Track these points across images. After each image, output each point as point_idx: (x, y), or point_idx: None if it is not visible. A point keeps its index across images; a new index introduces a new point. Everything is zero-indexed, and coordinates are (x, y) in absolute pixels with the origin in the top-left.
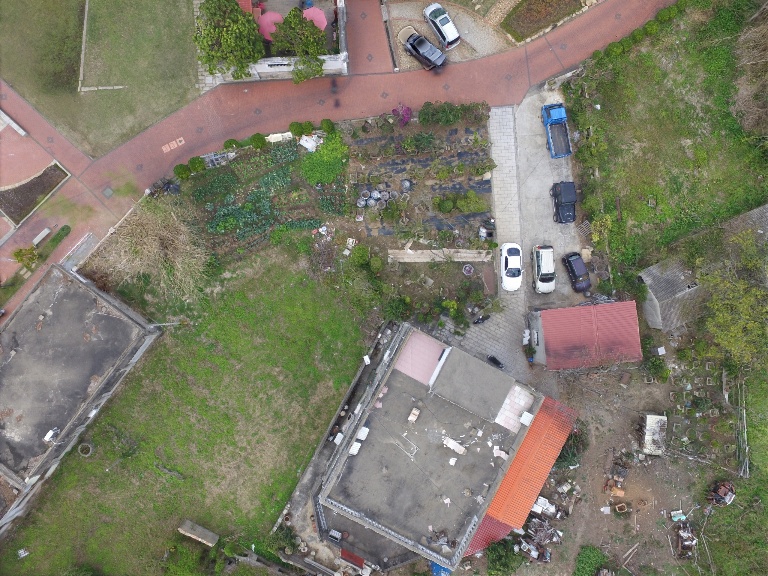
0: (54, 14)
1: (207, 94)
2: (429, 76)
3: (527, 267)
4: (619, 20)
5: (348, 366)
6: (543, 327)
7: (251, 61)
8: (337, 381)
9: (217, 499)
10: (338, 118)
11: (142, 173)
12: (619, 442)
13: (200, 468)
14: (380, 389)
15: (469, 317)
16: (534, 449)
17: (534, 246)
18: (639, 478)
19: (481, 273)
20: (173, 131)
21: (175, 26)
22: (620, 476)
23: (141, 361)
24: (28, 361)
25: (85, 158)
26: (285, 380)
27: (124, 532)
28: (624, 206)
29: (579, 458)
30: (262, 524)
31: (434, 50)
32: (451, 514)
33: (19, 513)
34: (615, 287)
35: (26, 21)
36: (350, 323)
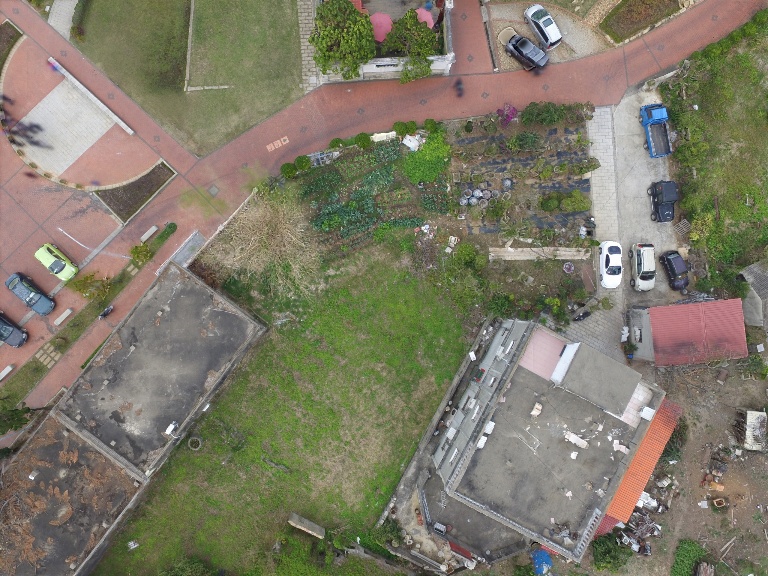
0: (160, 15)
1: (311, 94)
2: (529, 76)
3: (625, 265)
4: (716, 21)
5: (450, 362)
6: (651, 324)
7: (362, 62)
8: (439, 377)
9: (323, 492)
10: (439, 118)
11: (247, 172)
12: (716, 438)
13: (306, 462)
14: (506, 384)
15: (569, 314)
16: (641, 444)
17: (634, 244)
18: (736, 473)
19: (580, 271)
20: (277, 130)
21: (280, 27)
22: (719, 471)
23: (247, 357)
24: (147, 356)
25: (191, 157)
26: (388, 376)
27: (231, 525)
28: (721, 205)
29: (681, 453)
30: (366, 517)
31: (537, 51)
32: (573, 507)
33: (129, 506)
34: (713, 285)
35: (132, 21)
36: (452, 320)
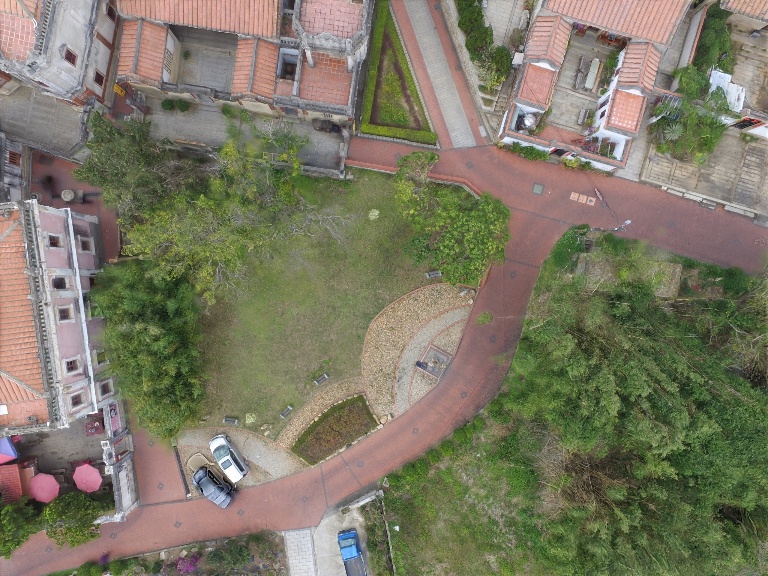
0: None
1: None
2: None
3: None
4: (417, 435)
5: None
6: None
7: None
8: None
9: None
10: (131, 551)
11: None
12: None
13: None
14: None
15: None
16: None
17: None
18: None
19: None
20: None
21: None
22: None
23: None
24: None
25: None
26: None
27: None
28: None
29: None
30: None
31: (218, 494)
32: None
33: None
34: None
35: None
36: None
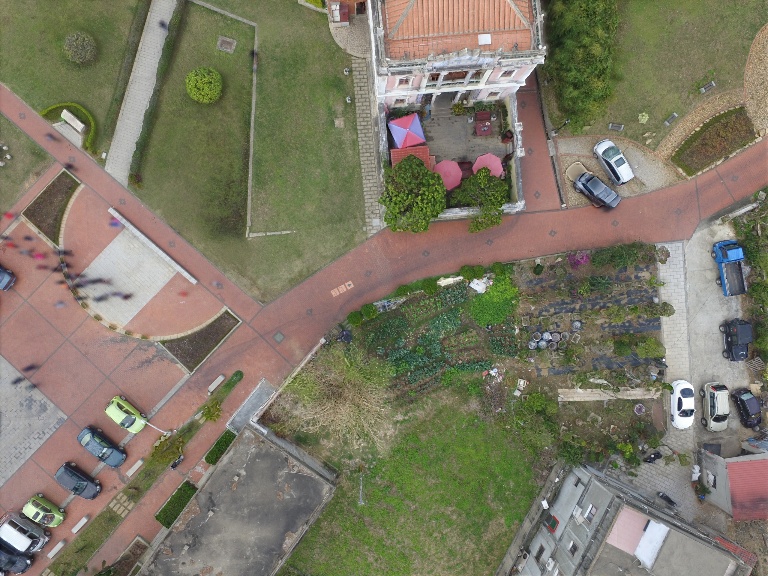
0: (218, 158)
1: (375, 237)
2: (598, 212)
3: (696, 403)
4: None
5: (520, 505)
6: (729, 479)
7: None
8: (509, 519)
9: None
10: (506, 258)
11: (312, 318)
12: None
13: None
14: (593, 565)
15: (639, 454)
16: None
17: (706, 385)
18: None
19: (650, 410)
20: (341, 275)
21: (341, 169)
22: None
23: None
24: (225, 520)
25: (255, 304)
26: (459, 519)
27: None
28: None
29: None
30: None
31: (609, 192)
32: None
33: None
34: None
35: (190, 166)
36: (522, 463)
